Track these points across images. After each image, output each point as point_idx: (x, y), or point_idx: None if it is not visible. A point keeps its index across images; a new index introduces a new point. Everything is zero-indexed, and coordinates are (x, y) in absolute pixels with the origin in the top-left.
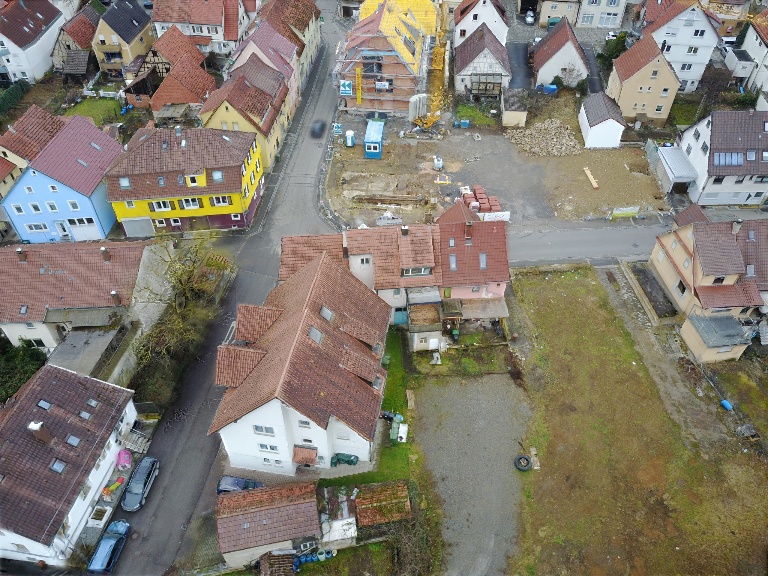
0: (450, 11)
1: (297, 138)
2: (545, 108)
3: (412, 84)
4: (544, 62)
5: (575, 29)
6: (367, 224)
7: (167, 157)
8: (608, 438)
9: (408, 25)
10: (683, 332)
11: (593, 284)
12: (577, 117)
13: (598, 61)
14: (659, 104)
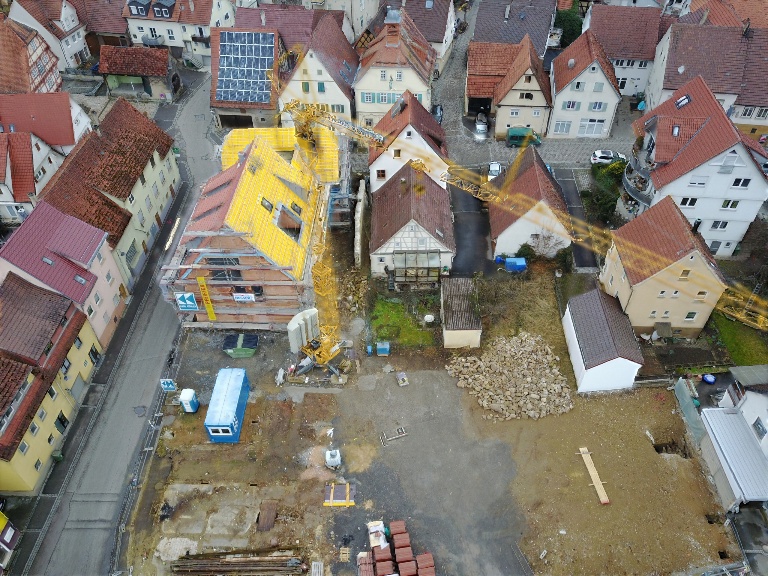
0: (367, 123)
1: (106, 394)
2: (510, 303)
3: (294, 291)
4: (504, 227)
5: (546, 142)
6: None
7: None
8: None
9: (289, 183)
10: None
11: None
12: (560, 321)
13: (583, 204)
14: (691, 311)
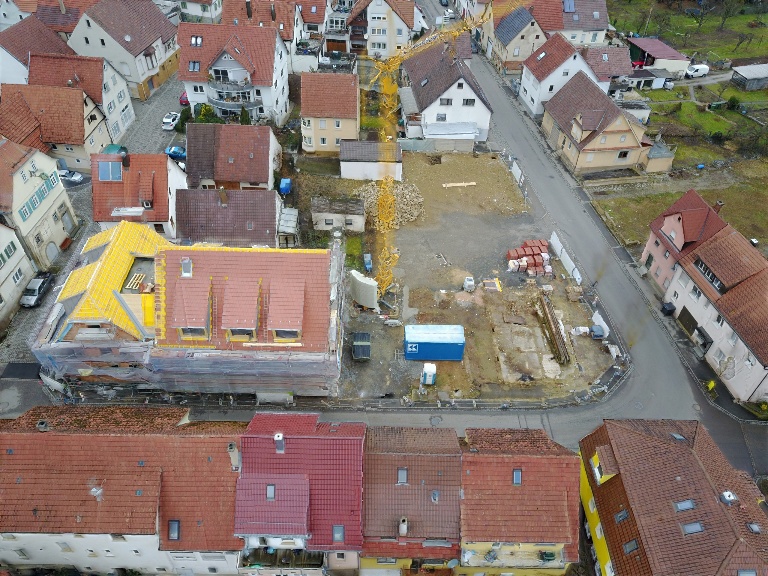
0: (36, 241)
1: None
2: None
3: None
4: (267, 167)
5: None
6: (601, 351)
7: (763, 526)
8: (766, 214)
9: None
10: (650, 169)
11: (615, 203)
12: (341, 178)
13: None
14: None
